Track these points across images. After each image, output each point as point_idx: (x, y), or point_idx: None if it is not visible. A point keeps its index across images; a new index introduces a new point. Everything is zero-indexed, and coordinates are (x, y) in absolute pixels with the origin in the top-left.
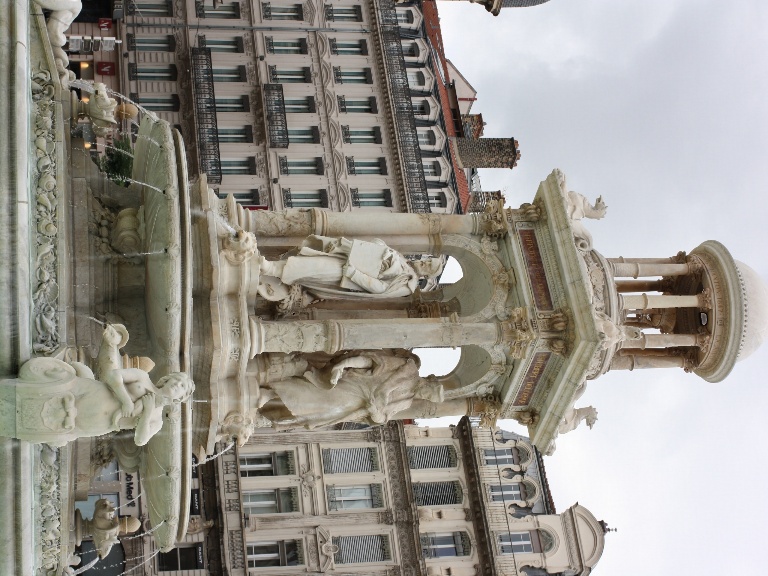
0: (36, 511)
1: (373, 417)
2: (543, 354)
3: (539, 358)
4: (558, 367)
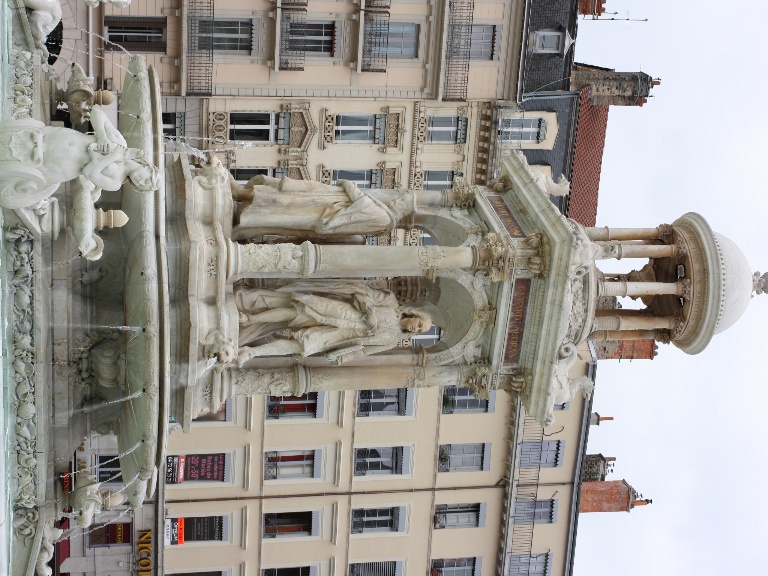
0: (10, 72)
1: (347, 184)
2: (494, 198)
3: (494, 201)
4: (515, 198)
